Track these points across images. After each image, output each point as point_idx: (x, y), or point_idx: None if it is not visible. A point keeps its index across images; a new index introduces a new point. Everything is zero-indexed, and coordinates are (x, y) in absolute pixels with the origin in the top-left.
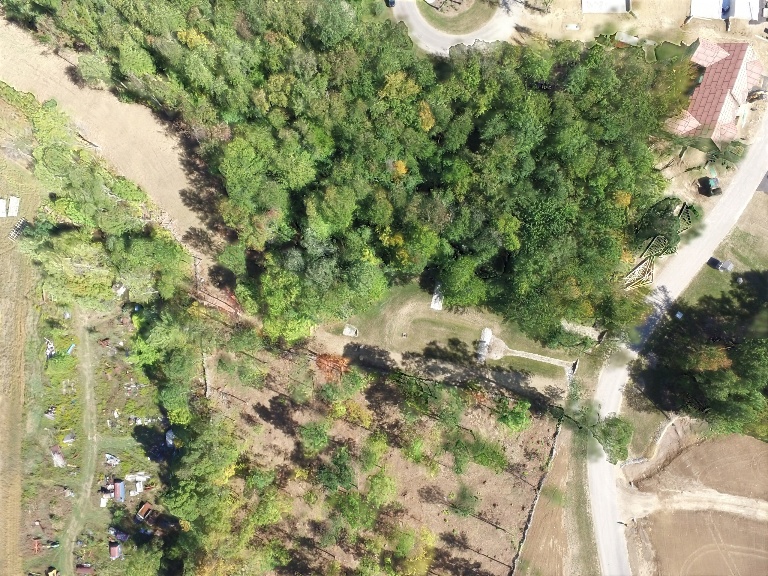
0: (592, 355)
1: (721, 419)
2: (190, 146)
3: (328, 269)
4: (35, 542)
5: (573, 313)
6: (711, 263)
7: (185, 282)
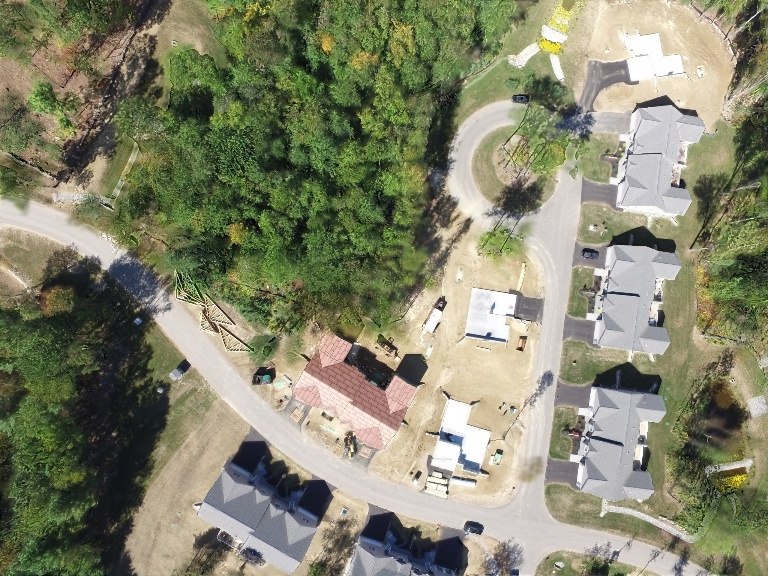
0: (115, 224)
1: None
2: None
3: None
4: None
5: None
6: (185, 363)
7: None
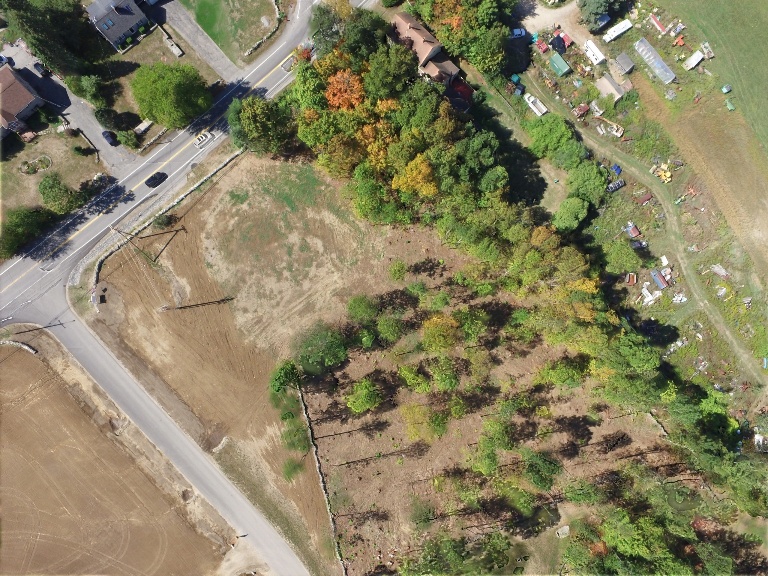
0: None
1: None
2: None
3: None
4: None
5: None
6: None
7: None
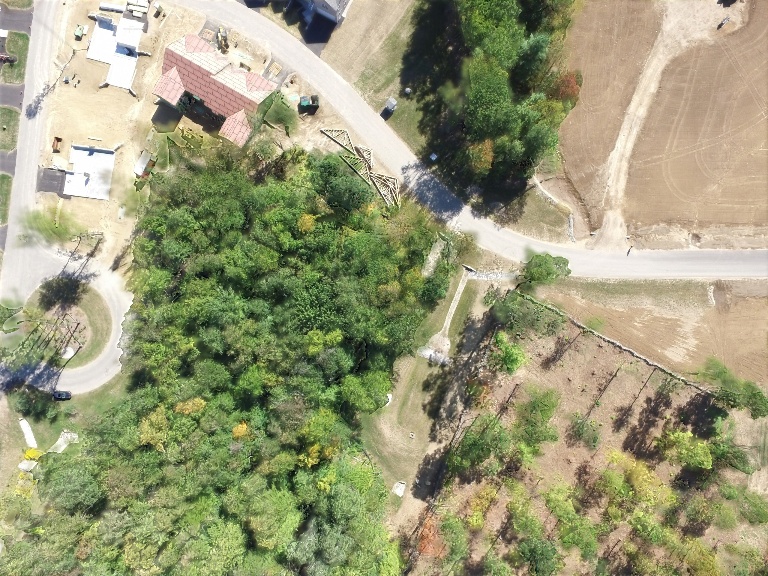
0: (460, 251)
1: (542, 154)
2: None
3: (332, 541)
4: None
5: None
6: (386, 117)
7: None
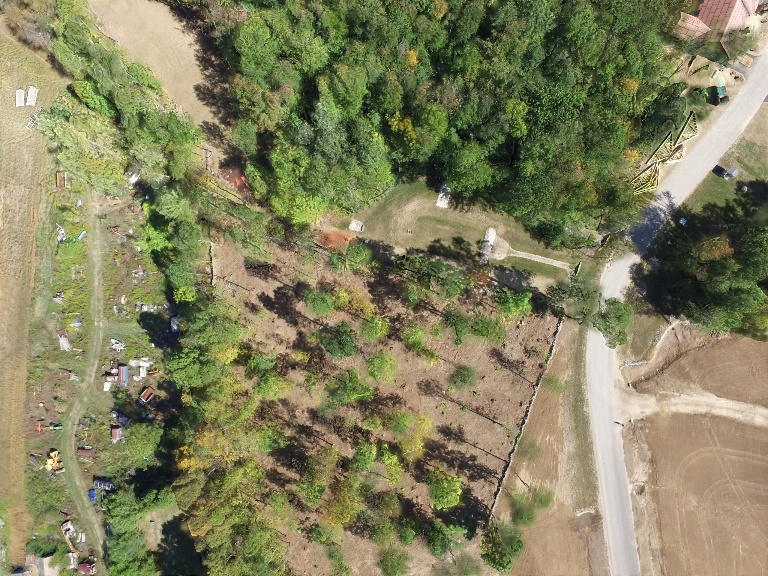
0: (595, 257)
1: (721, 311)
2: (206, 43)
3: (337, 141)
4: (38, 423)
5: (577, 203)
6: (716, 171)
7: (196, 169)
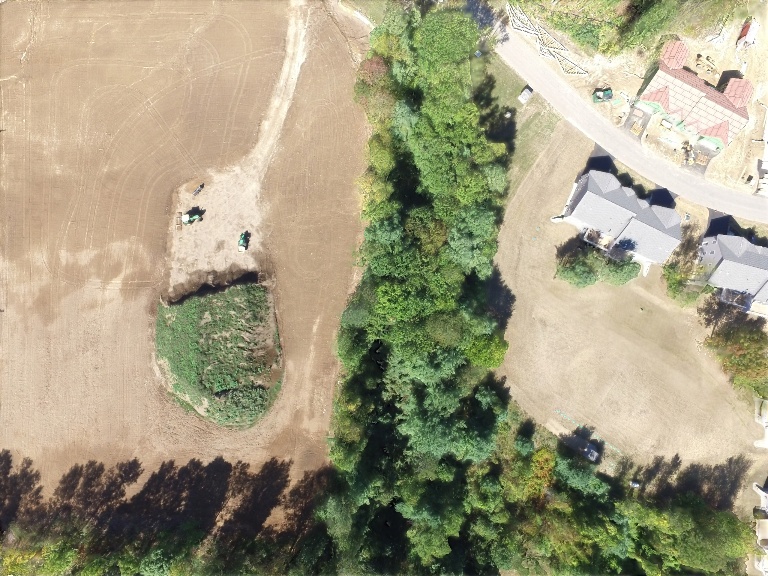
0: None
1: None
2: None
3: None
4: None
5: None
6: (527, 88)
7: None
